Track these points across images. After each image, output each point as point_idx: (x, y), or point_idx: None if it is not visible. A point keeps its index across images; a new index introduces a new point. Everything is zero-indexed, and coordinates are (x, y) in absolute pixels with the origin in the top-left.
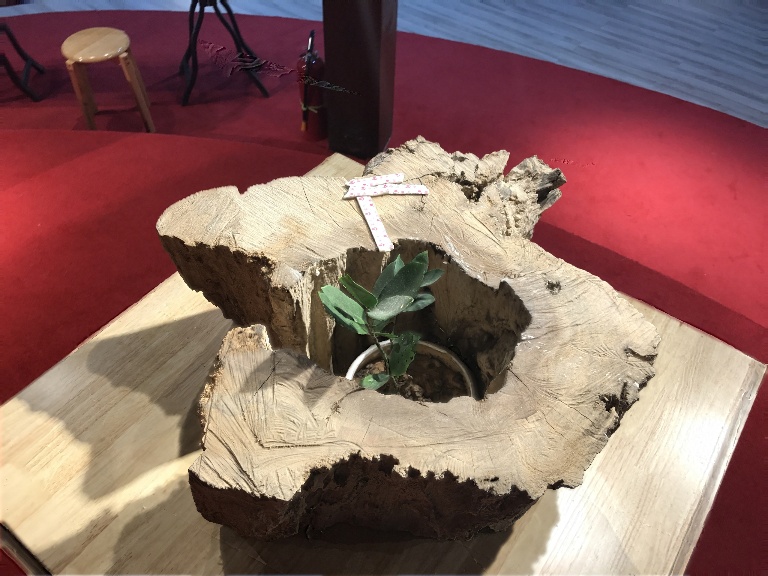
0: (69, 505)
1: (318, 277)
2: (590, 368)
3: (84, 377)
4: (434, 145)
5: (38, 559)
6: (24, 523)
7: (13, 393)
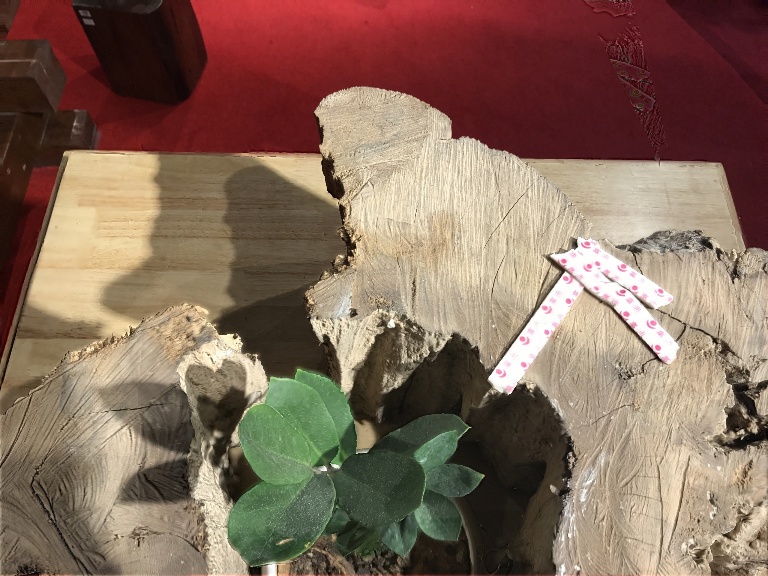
0: (86, 289)
1: (392, 328)
2: None
3: (216, 187)
4: None
5: (23, 310)
6: (49, 270)
7: (167, 149)
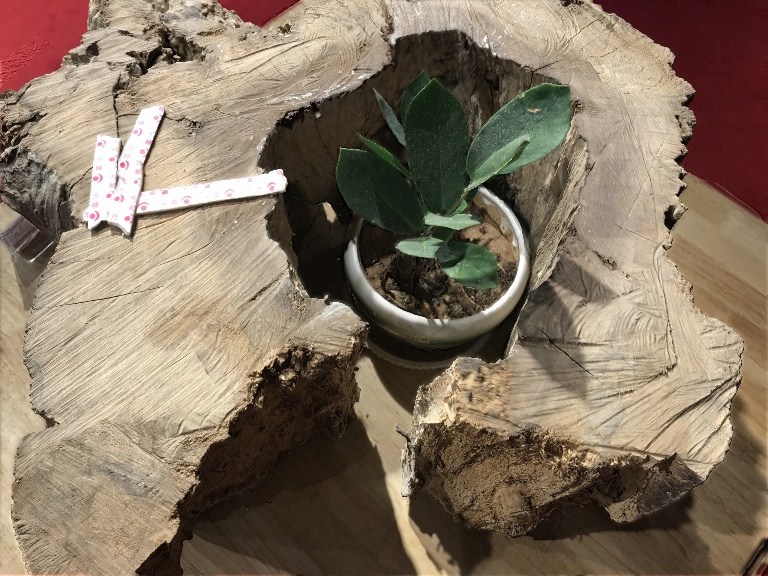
0: None
1: None
2: (526, 2)
3: None
4: (34, 83)
5: None
6: None
7: None
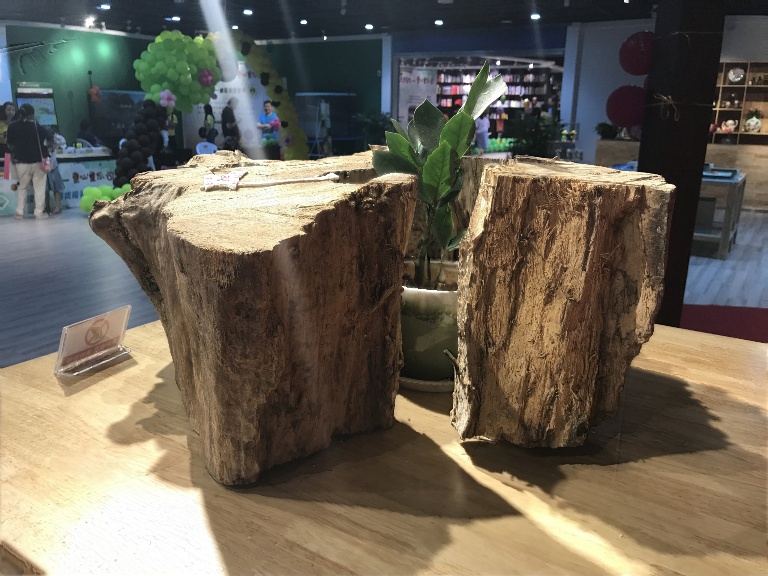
0: None
1: None
2: None
3: None
4: None
5: None
6: None
7: None
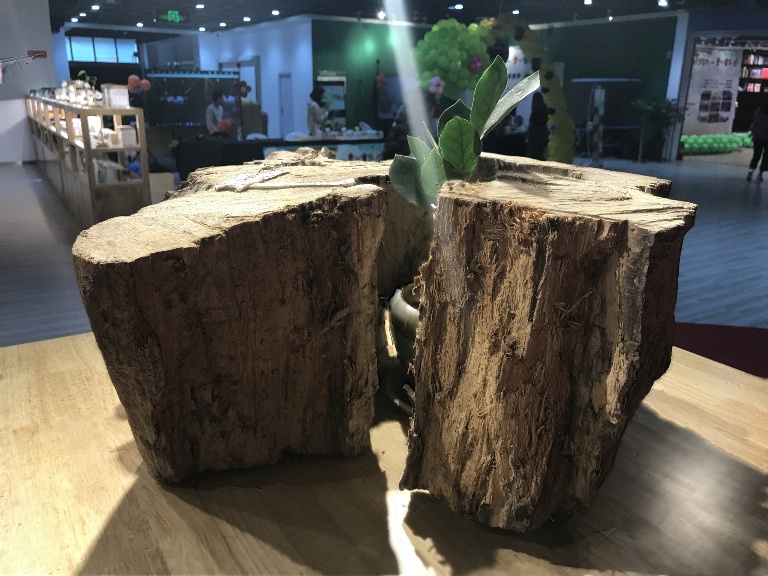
0: None
1: None
2: None
3: None
4: None
5: None
6: None
7: None
